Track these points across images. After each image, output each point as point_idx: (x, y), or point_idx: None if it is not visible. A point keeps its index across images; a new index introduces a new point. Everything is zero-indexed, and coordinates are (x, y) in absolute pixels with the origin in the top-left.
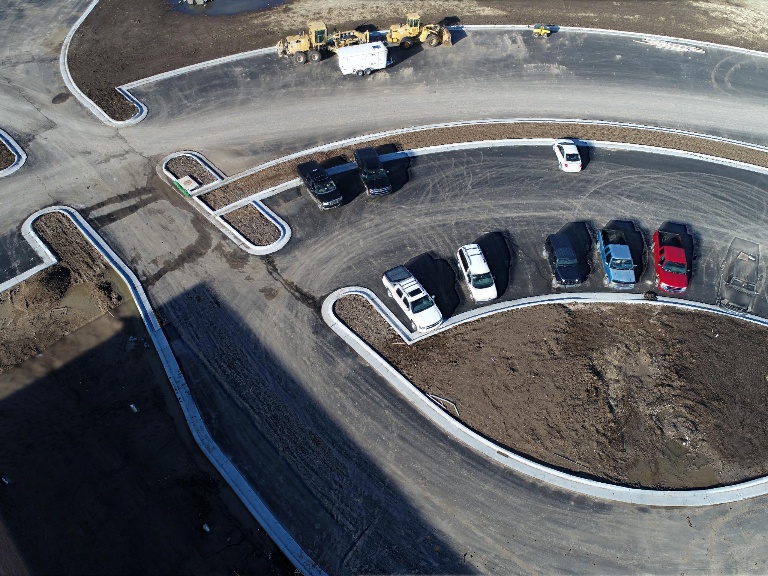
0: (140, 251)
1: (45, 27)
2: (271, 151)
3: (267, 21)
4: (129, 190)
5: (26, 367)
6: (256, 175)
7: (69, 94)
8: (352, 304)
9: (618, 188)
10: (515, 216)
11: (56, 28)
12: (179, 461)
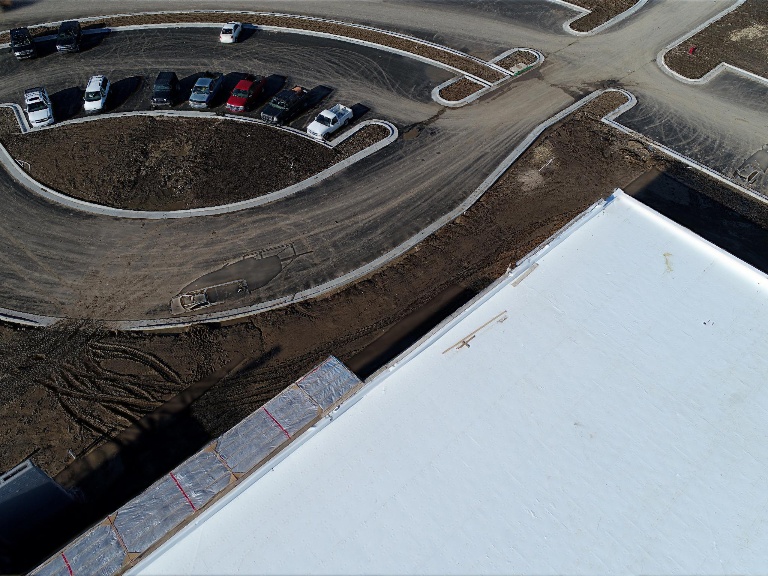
0: None
1: None
2: (7, 25)
3: None
4: None
5: None
6: None
7: None
8: (1, 112)
9: (256, 54)
10: (161, 68)
11: None
12: None
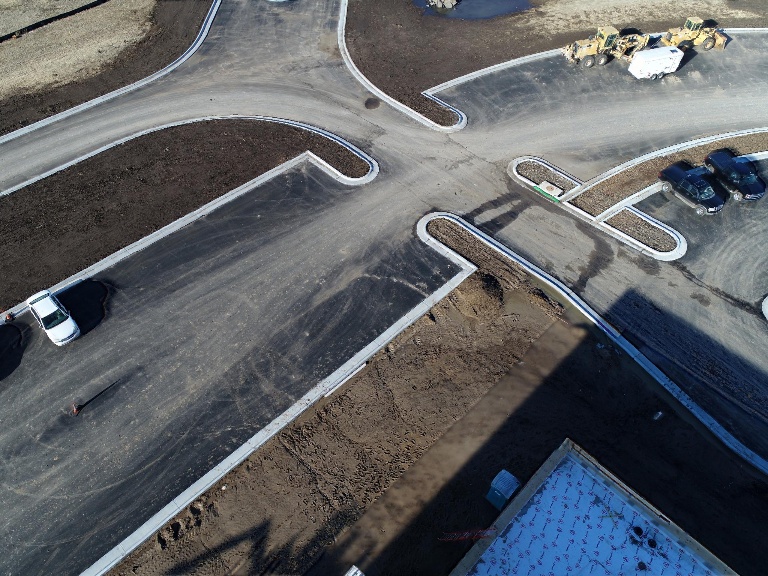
0: (548, 257)
1: (311, 31)
2: (611, 156)
3: (530, 25)
4: (496, 196)
5: (517, 374)
6: (611, 180)
7: (378, 99)
8: None
9: None
10: None
11: (322, 32)
12: (730, 468)
